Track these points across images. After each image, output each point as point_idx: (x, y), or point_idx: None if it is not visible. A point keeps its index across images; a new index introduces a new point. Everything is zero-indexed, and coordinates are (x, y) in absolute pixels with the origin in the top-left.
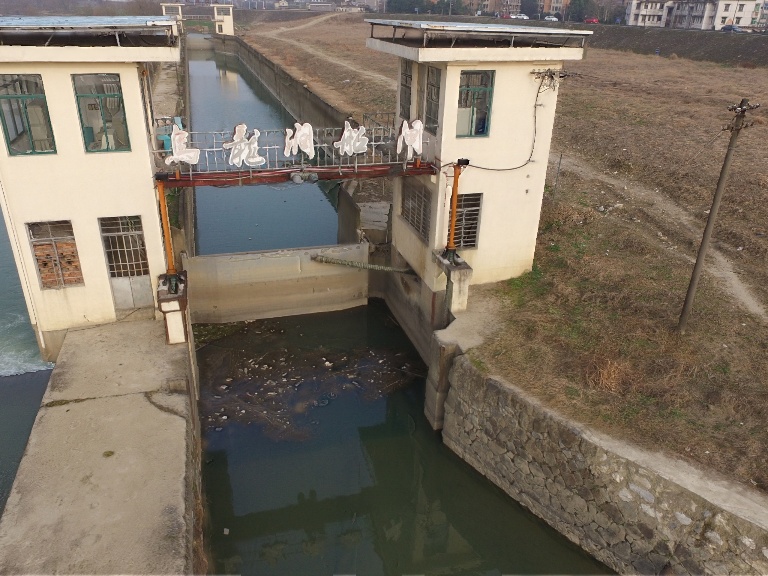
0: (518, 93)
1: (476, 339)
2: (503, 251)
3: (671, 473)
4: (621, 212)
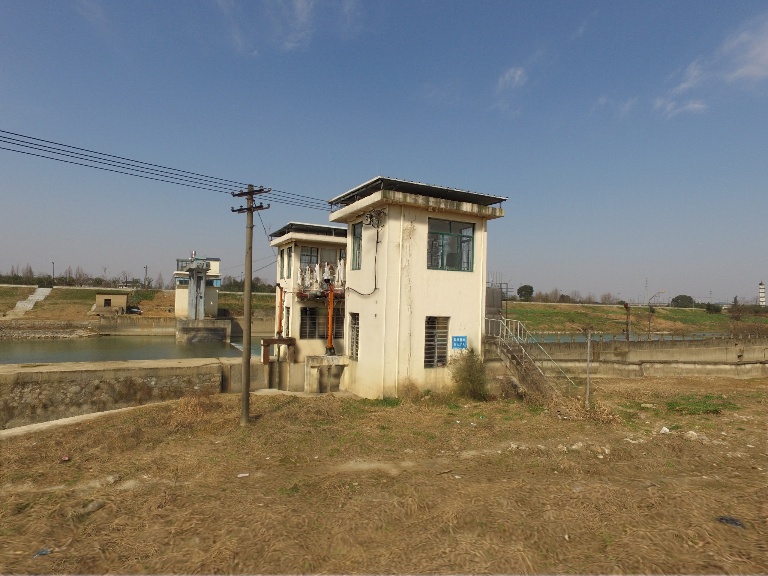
0: (371, 235)
1: (263, 394)
2: (368, 370)
3: (71, 418)
4: (665, 437)
